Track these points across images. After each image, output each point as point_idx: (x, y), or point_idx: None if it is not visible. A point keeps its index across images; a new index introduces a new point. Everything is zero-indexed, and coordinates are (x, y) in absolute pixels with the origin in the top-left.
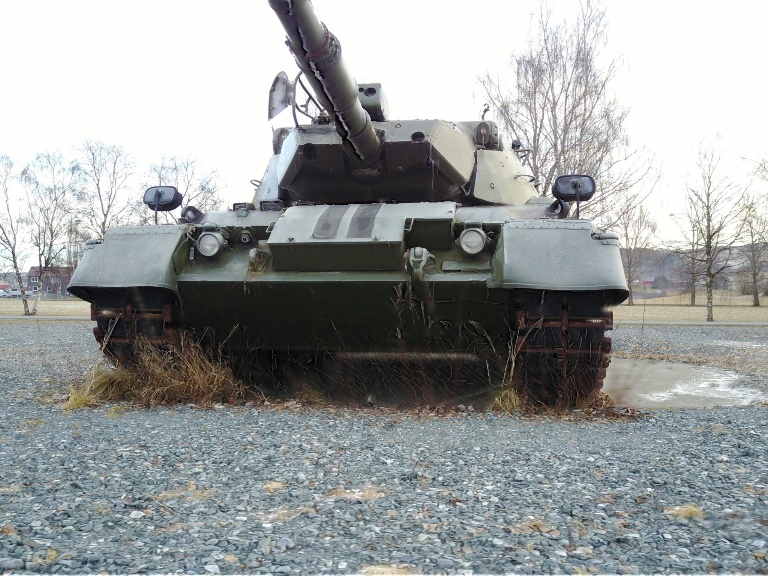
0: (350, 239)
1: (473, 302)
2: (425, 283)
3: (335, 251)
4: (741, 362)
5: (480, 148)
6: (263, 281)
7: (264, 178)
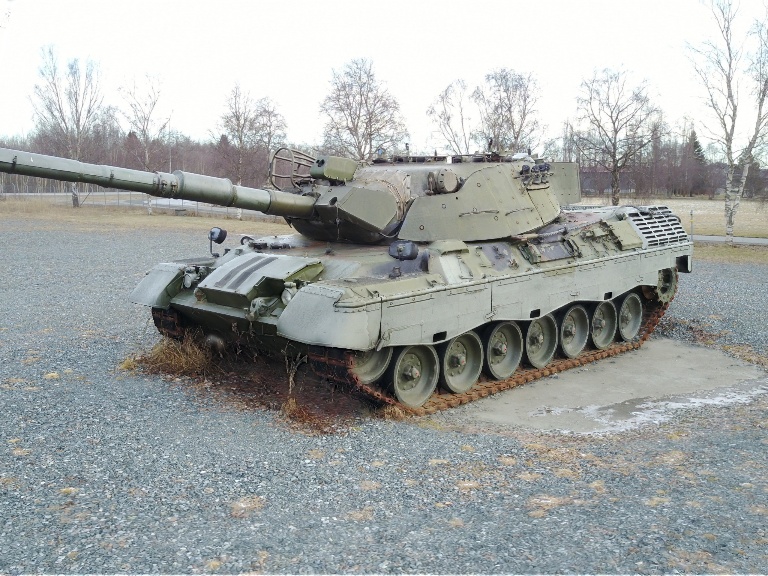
0: (227, 289)
1: None
2: (258, 322)
3: None
4: None
5: (428, 193)
6: (199, 308)
7: None
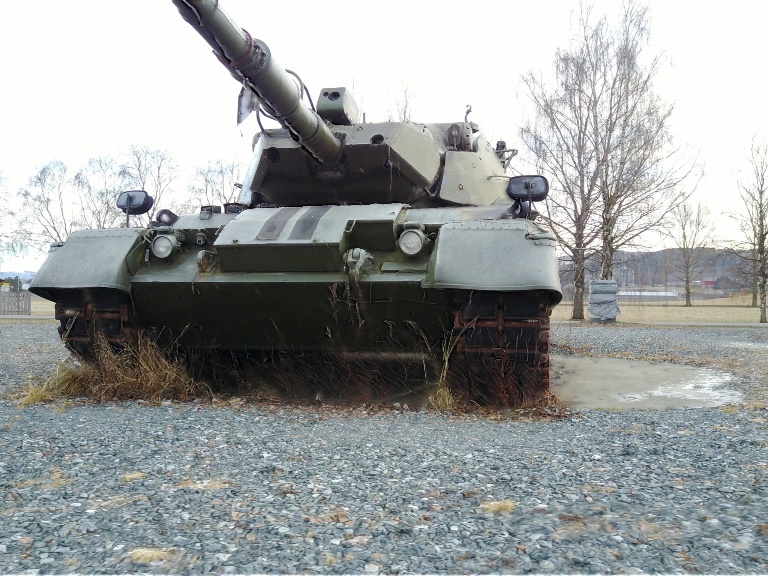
0: (291, 241)
1: (412, 302)
2: (362, 283)
3: (277, 252)
4: (743, 364)
5: (451, 149)
6: (210, 282)
7: (244, 181)
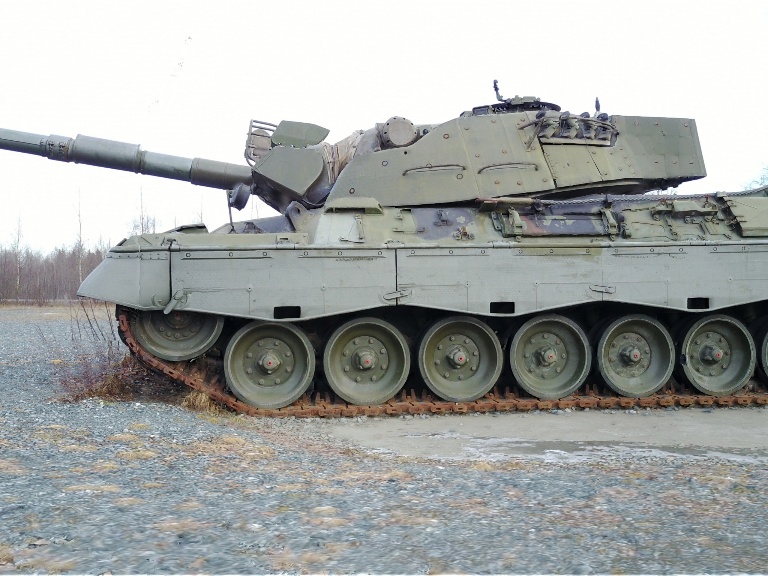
0: None
1: None
2: None
3: None
4: None
5: None
6: None
7: None
